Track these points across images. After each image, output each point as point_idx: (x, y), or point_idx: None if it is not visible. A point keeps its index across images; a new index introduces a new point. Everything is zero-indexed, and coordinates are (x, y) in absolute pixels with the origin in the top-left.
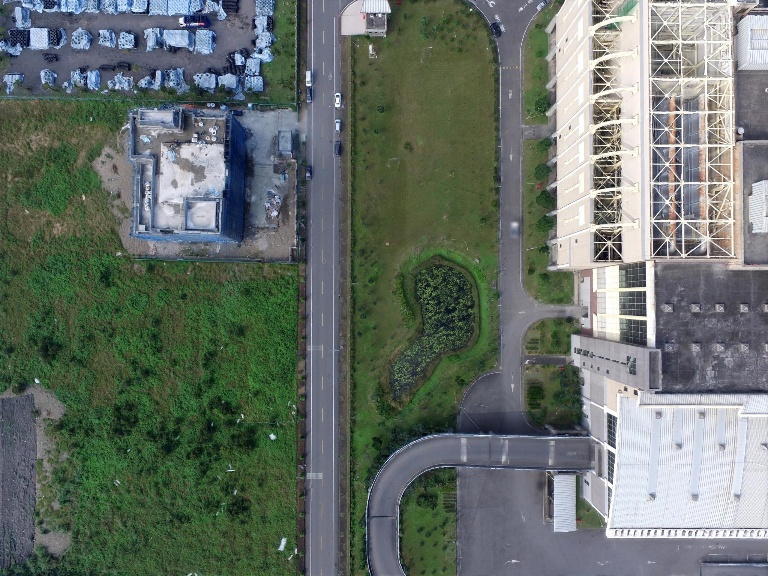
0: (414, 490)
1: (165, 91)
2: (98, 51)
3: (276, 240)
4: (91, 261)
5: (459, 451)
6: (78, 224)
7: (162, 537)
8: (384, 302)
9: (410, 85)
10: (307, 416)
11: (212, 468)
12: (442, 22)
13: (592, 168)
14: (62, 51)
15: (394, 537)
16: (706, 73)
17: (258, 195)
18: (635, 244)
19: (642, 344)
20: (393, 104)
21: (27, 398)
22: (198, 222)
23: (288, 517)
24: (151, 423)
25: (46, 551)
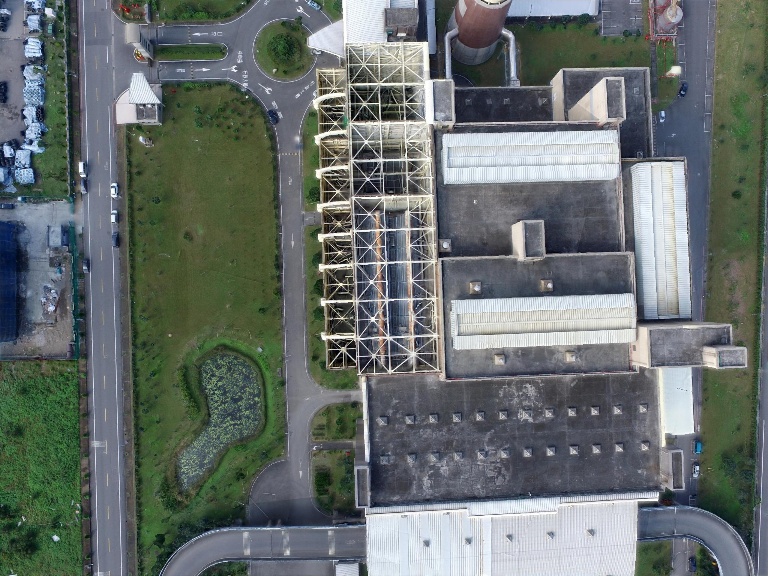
0: None
1: None
2: None
3: (54, 336)
4: None
5: (242, 545)
6: None
7: None
8: (168, 395)
9: (188, 174)
10: (92, 514)
11: None
12: (218, 110)
13: None
14: None
15: None
16: (407, 191)
17: (34, 290)
18: None
19: None
20: (171, 193)
21: None
22: None
23: None
24: None
25: None
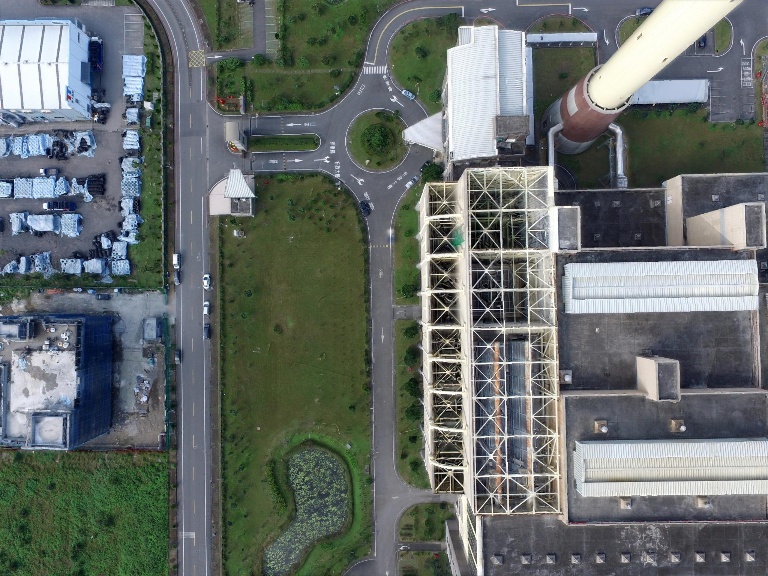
0: None
1: (28, 280)
2: None
3: (146, 426)
4: None
5: None
6: None
7: None
8: (256, 489)
9: (279, 265)
10: None
11: None
12: (310, 202)
13: (431, 397)
14: None
15: None
16: (529, 322)
17: (127, 380)
18: (468, 487)
19: None
20: (262, 285)
21: None
22: (46, 436)
23: None
24: None
25: None
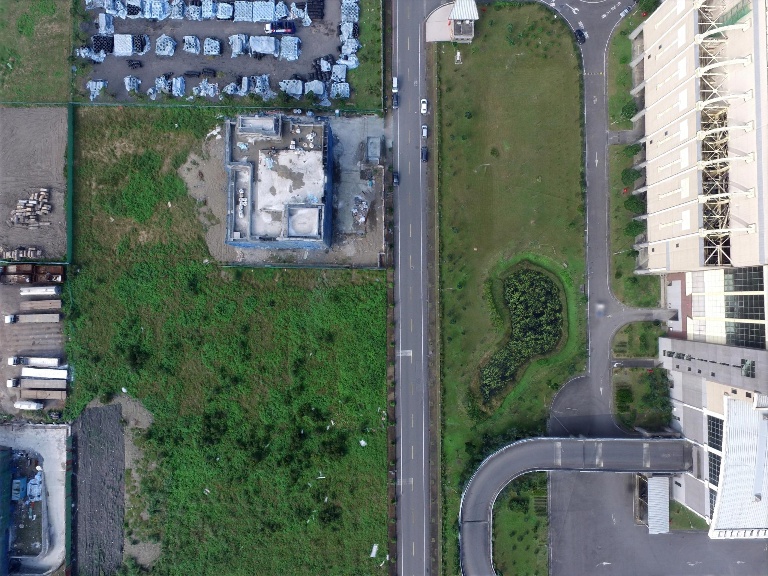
0: (507, 494)
1: (253, 98)
2: (182, 57)
3: (364, 246)
4: (178, 269)
5: (553, 455)
6: (164, 231)
7: (253, 546)
8: (473, 307)
9: (496, 91)
10: (397, 422)
11: (303, 475)
12: (527, 29)
13: (701, 174)
14: (146, 57)
15: (486, 541)
16: None
17: (345, 201)
18: (750, 249)
19: (759, 347)
20: (479, 110)
21: (114, 407)
22: (300, 229)
23: (380, 523)
24: (241, 431)
25: (136, 562)
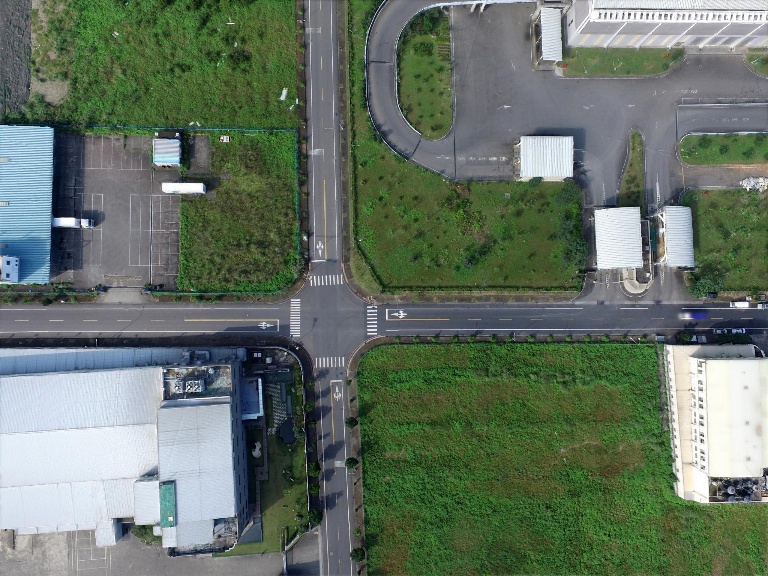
0: None
1: None
2: None
3: None
4: None
5: None
6: None
7: (163, 86)
8: None
9: None
10: None
11: (212, 20)
12: None
13: None
14: None
15: (392, 83)
16: None
17: None
18: None
19: None
20: None
21: None
22: None
23: (288, 67)
24: None
25: (43, 99)
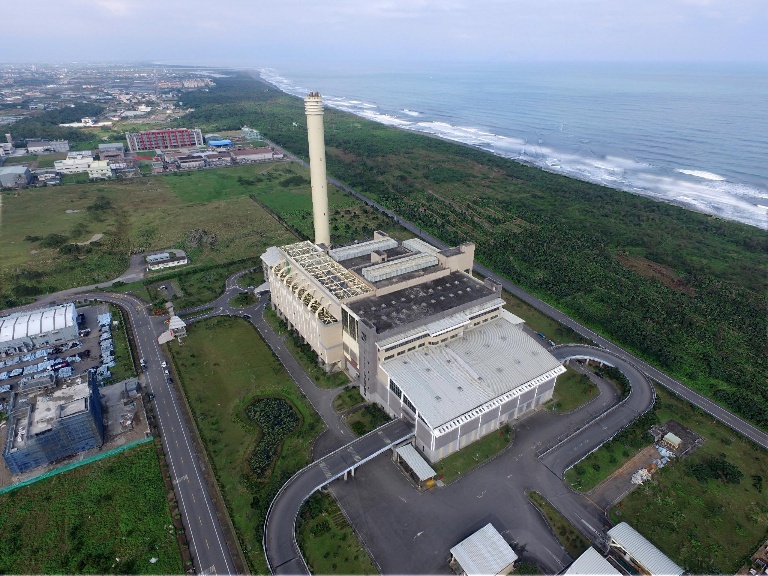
0: None
1: None
2: None
3: (132, 435)
4: None
5: (322, 473)
6: None
7: None
8: (228, 431)
9: (208, 346)
10: (186, 528)
11: None
12: (217, 323)
13: (304, 304)
14: None
15: (305, 575)
16: None
17: (114, 420)
18: (335, 308)
19: None
20: (200, 354)
21: None
22: (70, 413)
23: None
24: None
25: None
